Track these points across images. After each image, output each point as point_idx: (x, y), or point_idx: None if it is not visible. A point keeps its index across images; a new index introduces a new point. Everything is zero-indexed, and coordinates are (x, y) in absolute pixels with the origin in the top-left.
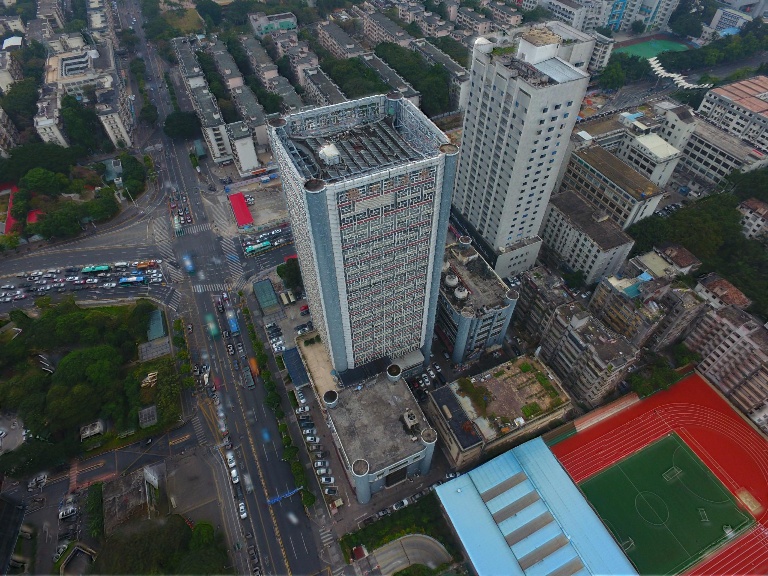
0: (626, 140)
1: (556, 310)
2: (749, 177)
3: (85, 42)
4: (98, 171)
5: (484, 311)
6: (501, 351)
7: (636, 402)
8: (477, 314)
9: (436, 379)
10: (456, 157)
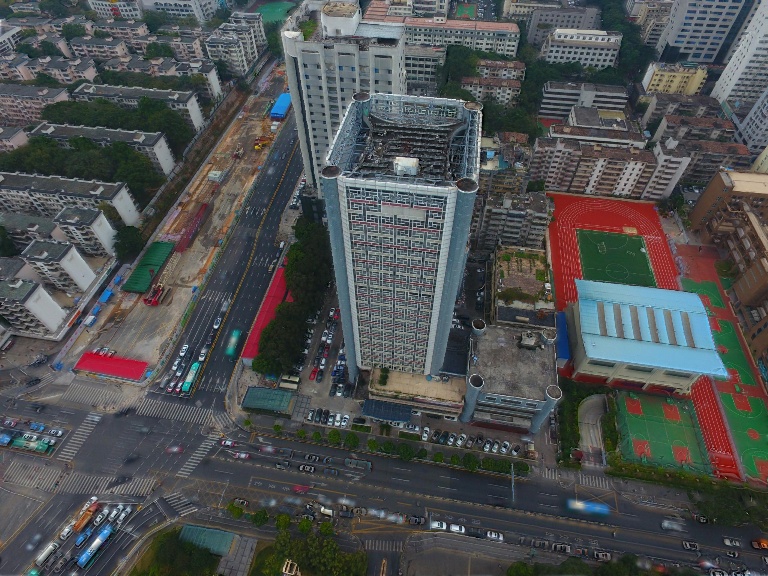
0: None
1: (487, 207)
2: (451, 65)
3: None
4: None
5: None
6: None
7: (549, 230)
8: None
9: (461, 321)
10: None
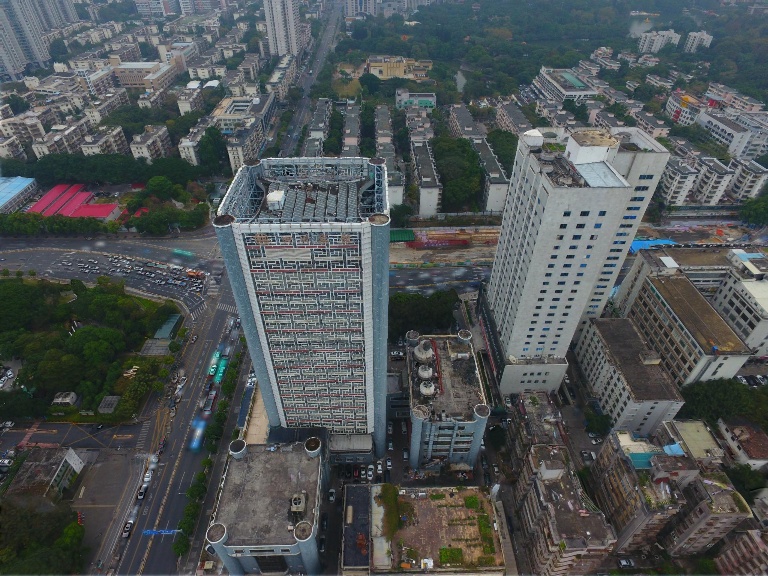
0: (729, 281)
1: (532, 448)
2: None
3: (257, 91)
4: (208, 189)
5: (442, 417)
6: (470, 474)
7: None
8: (431, 417)
9: (381, 476)
10: (384, 229)
